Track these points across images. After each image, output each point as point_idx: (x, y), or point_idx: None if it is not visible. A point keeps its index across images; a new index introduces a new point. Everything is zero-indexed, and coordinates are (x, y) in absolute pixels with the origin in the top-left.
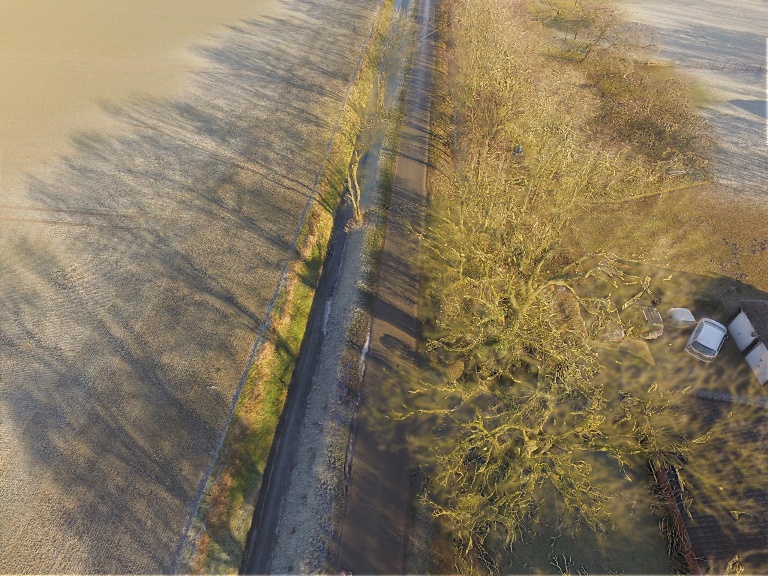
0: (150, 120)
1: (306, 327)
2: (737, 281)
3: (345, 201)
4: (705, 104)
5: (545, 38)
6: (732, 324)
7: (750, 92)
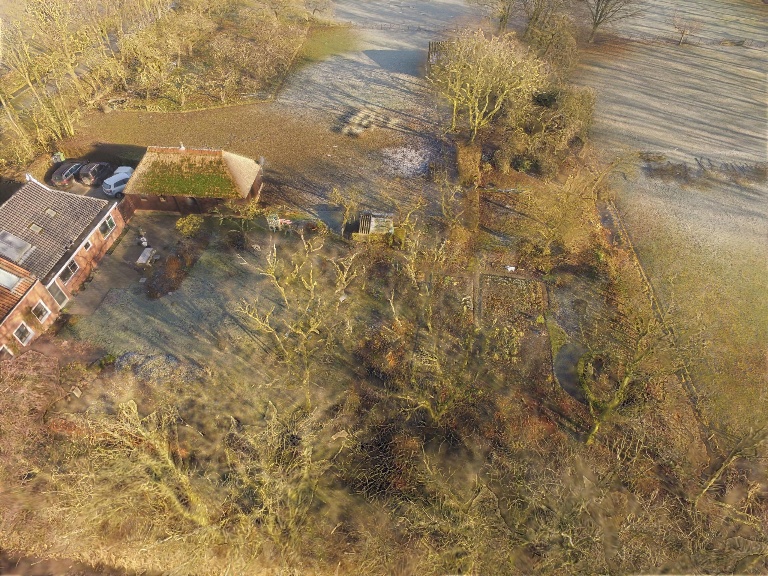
0: None
1: None
2: None
3: None
4: (341, 52)
5: (216, 0)
6: None
7: (389, 45)
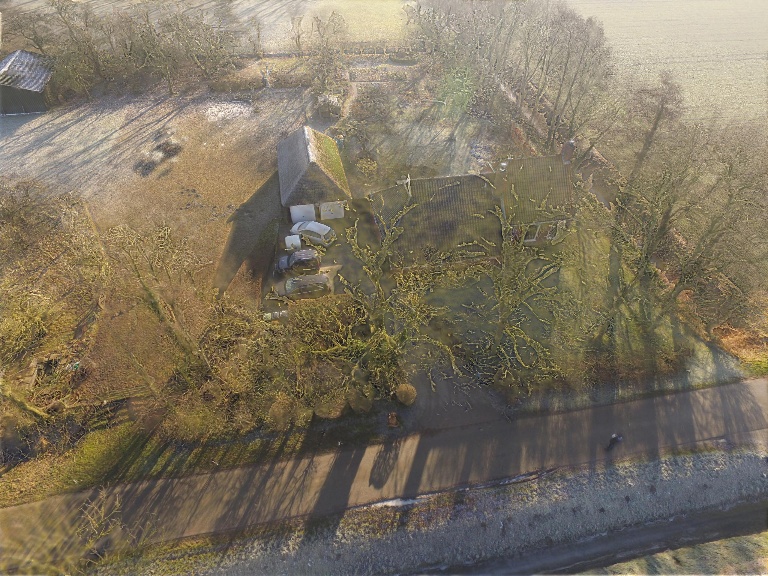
0: None
1: None
2: (237, 211)
3: None
4: None
5: None
6: (293, 219)
7: None
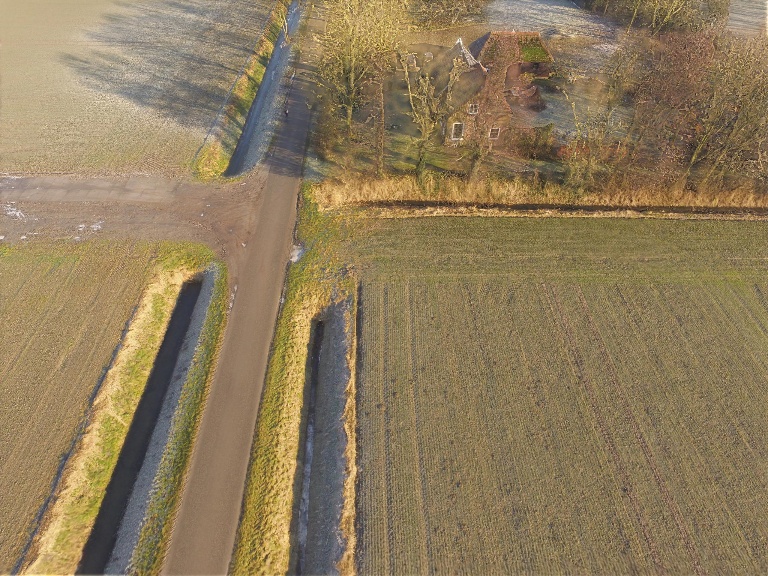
0: (151, 8)
1: (263, 78)
2: None
3: (280, 40)
4: None
5: None
6: None
7: None
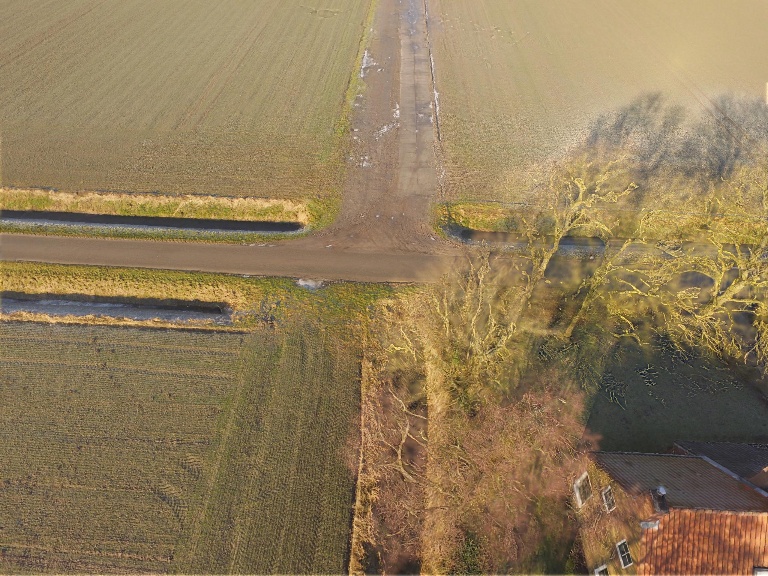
0: None
1: None
2: None
3: None
4: None
5: None
6: None
7: None
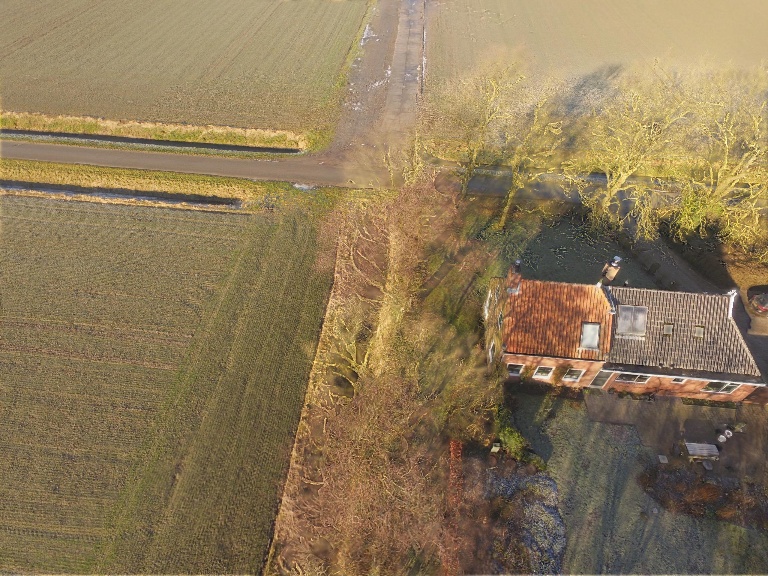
0: None
1: None
2: None
3: None
4: None
5: None
6: None
7: None
